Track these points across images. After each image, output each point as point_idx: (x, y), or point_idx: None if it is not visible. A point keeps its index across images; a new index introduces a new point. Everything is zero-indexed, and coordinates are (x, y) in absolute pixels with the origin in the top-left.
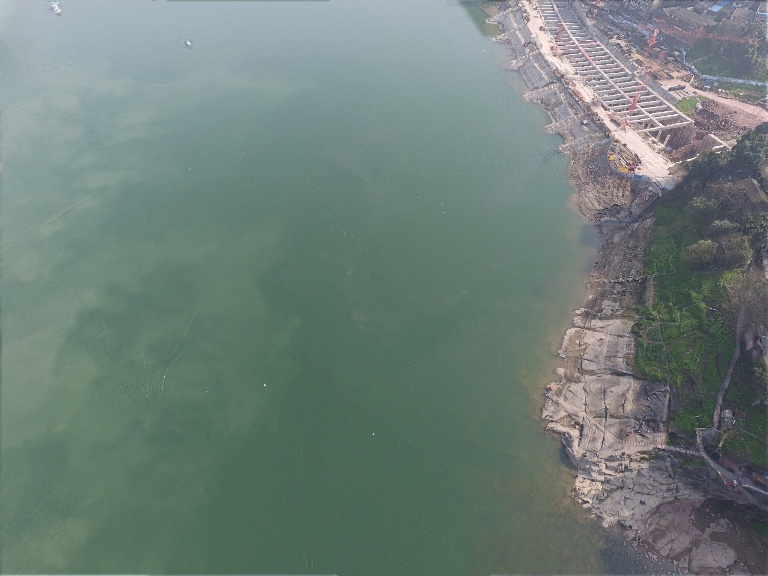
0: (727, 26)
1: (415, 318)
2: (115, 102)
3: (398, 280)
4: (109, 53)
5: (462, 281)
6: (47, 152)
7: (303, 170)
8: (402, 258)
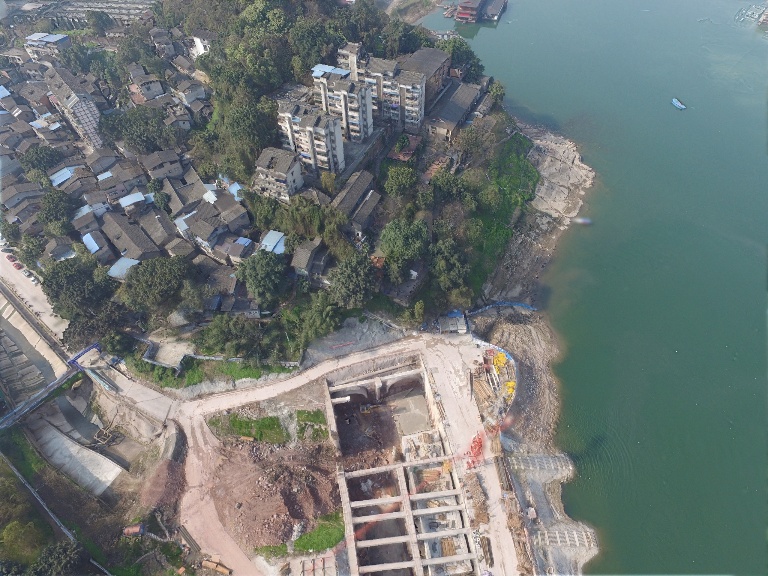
0: None
1: (706, 232)
2: None
3: (740, 263)
4: None
5: (676, 256)
6: None
7: None
8: (749, 285)
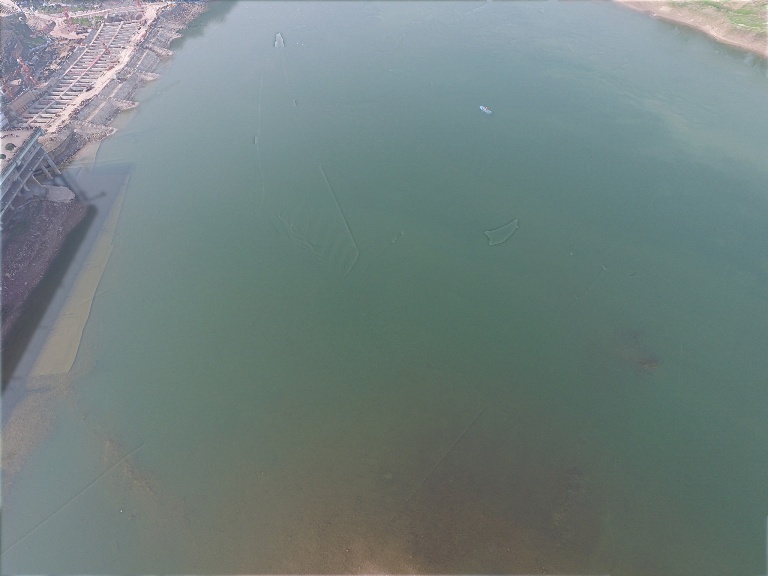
0: (7, 22)
1: None
2: (513, 58)
3: None
4: (604, 123)
5: None
6: (524, 25)
7: (338, 12)
8: None
